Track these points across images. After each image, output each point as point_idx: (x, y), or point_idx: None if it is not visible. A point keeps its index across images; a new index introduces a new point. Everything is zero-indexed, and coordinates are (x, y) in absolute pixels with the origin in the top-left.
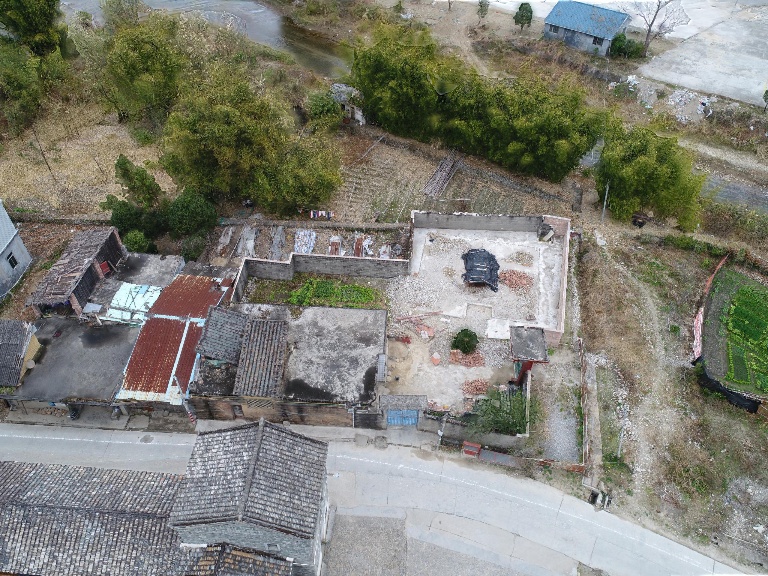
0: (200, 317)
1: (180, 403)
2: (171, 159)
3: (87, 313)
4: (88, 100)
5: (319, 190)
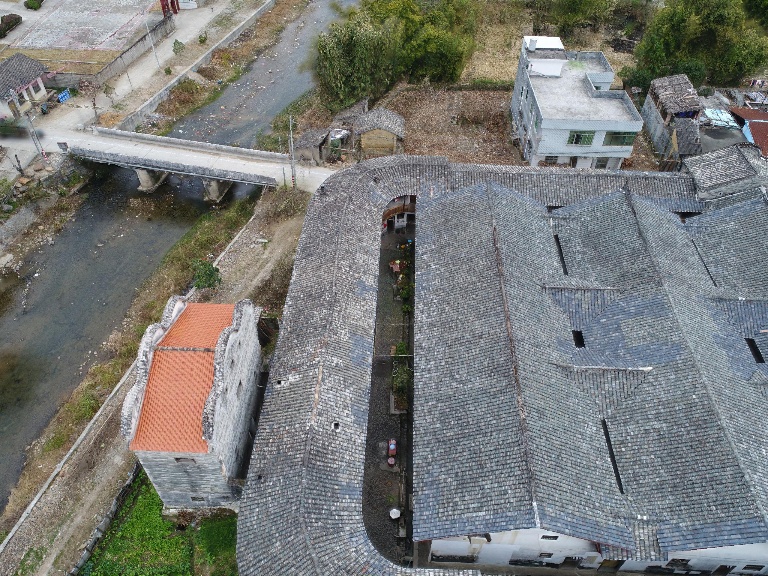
0: None
1: None
2: (663, 42)
3: (702, 121)
4: (495, 22)
5: None
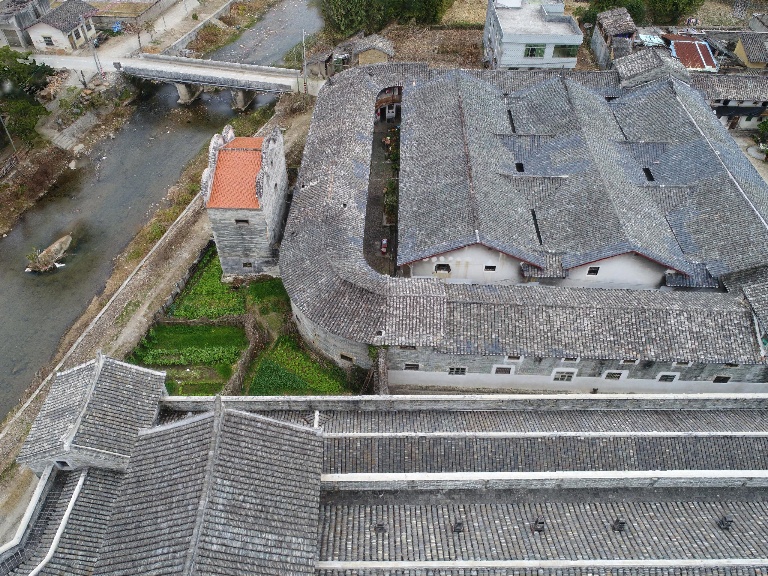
0: (700, 41)
1: (716, 71)
2: None
3: (637, 42)
4: None
5: (700, 2)
